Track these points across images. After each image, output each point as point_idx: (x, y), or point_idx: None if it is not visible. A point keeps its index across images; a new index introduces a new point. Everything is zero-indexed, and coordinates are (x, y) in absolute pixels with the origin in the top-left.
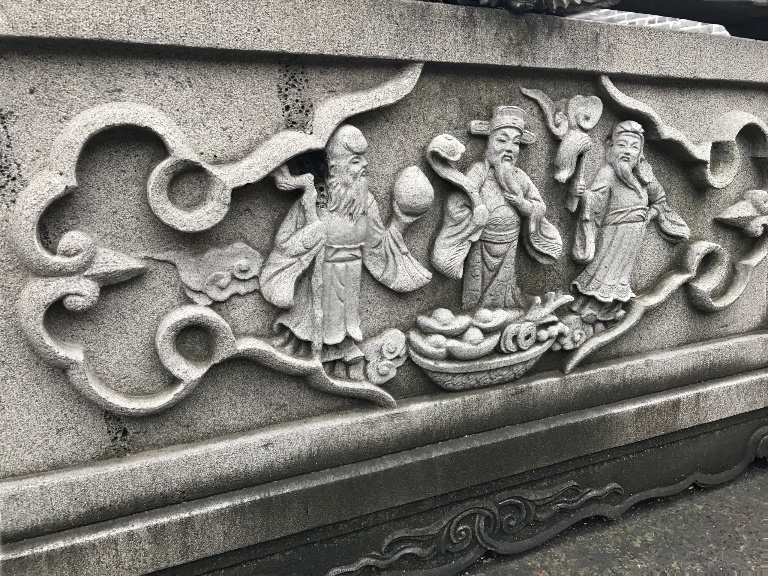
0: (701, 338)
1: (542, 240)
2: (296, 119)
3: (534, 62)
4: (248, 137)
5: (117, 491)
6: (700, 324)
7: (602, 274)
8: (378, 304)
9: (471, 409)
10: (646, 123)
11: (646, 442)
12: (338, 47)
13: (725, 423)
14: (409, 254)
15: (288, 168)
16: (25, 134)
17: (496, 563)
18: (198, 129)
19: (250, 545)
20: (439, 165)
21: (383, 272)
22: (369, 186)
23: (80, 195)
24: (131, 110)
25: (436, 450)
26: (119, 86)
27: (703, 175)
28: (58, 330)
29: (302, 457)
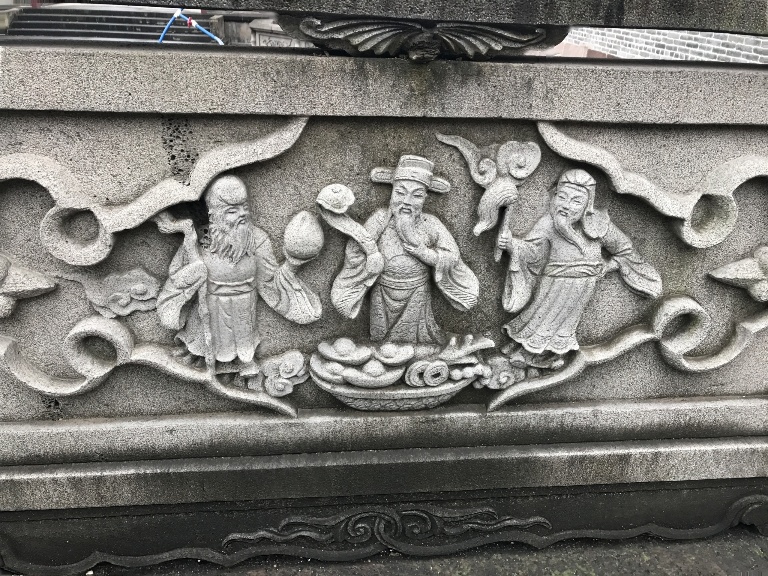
0: (682, 394)
1: (455, 288)
2: (182, 167)
3: (443, 112)
4: (136, 183)
5: (48, 446)
6: (680, 380)
7: (535, 323)
8: (278, 328)
9: (375, 429)
10: (603, 172)
11: (584, 487)
12: (212, 106)
13: (697, 484)
14: (302, 291)
15: (177, 210)
16: None
17: (401, 558)
18: (91, 176)
19: (154, 504)
20: (328, 214)
21: (277, 303)
22: (263, 226)
23: None
24: (21, 165)
25: (333, 459)
26: (19, 140)
27: (680, 232)
28: None
29: (204, 444)
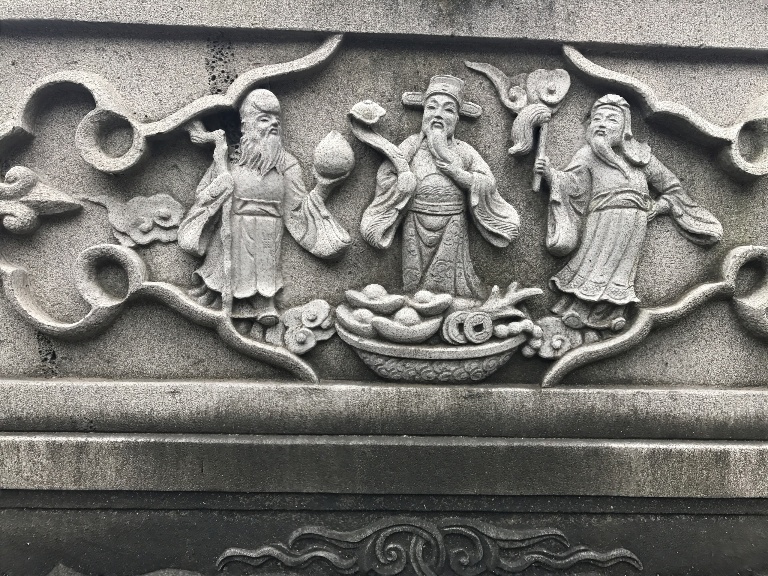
0: None
1: (493, 218)
2: (221, 87)
3: (470, 32)
4: (176, 101)
5: (34, 405)
6: None
7: (586, 269)
8: (304, 271)
9: (409, 404)
10: (636, 98)
11: (676, 503)
12: (254, 21)
13: None
14: (330, 219)
15: (211, 129)
16: (5, 95)
17: None
18: (134, 93)
19: (141, 490)
20: (359, 130)
21: (304, 236)
22: (294, 152)
23: (38, 143)
24: (72, 72)
25: (359, 440)
26: (75, 59)
27: (729, 158)
28: (9, 252)
29: (209, 414)
